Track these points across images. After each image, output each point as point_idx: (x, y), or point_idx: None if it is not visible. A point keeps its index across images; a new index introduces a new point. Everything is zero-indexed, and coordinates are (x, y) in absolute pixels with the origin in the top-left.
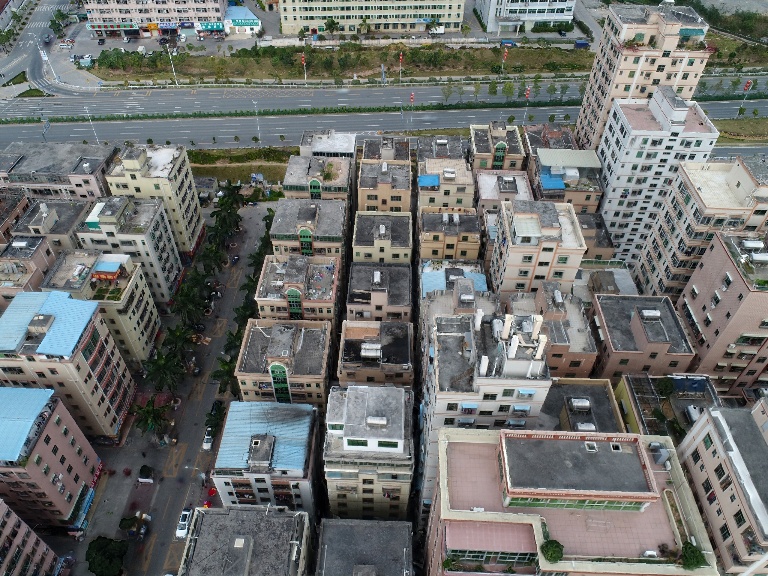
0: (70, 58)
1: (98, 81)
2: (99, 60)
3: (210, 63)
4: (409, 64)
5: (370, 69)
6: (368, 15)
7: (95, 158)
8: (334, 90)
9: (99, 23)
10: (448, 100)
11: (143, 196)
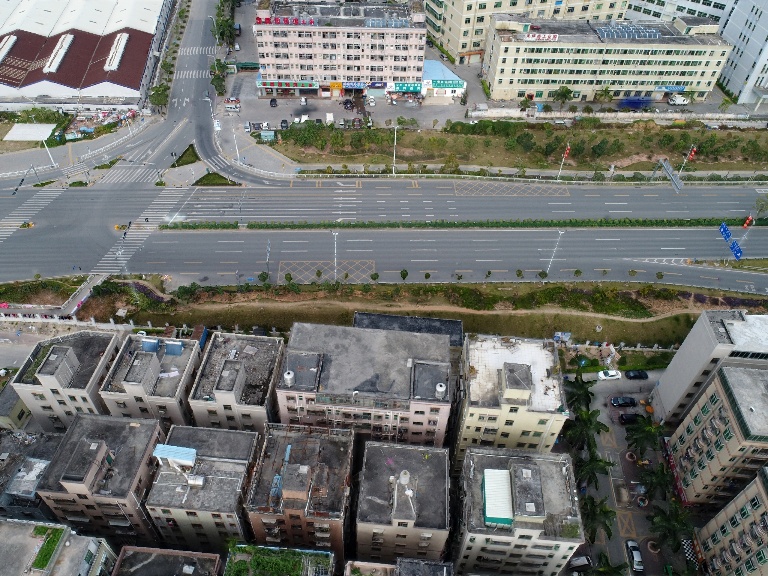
0: (245, 127)
1: (289, 163)
2: (282, 132)
3: (429, 144)
4: (673, 151)
5: (626, 157)
6: (600, 80)
7: (434, 363)
8: (593, 187)
9: (272, 80)
10: (749, 210)
11: (512, 429)
